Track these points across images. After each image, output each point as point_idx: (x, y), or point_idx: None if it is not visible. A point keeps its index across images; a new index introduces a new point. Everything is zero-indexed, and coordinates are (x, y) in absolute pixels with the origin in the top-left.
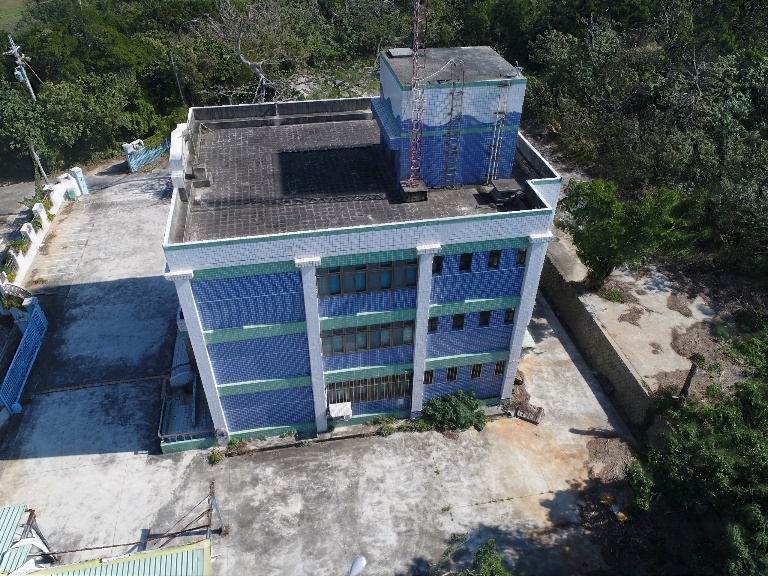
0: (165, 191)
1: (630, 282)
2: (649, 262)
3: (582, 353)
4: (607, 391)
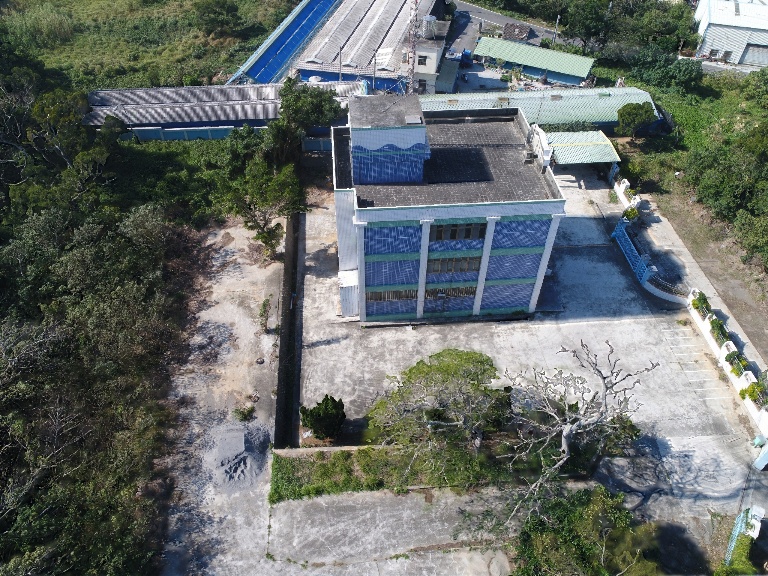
0: (659, 452)
1: (242, 258)
2: (213, 273)
3: (295, 246)
4: (297, 223)
